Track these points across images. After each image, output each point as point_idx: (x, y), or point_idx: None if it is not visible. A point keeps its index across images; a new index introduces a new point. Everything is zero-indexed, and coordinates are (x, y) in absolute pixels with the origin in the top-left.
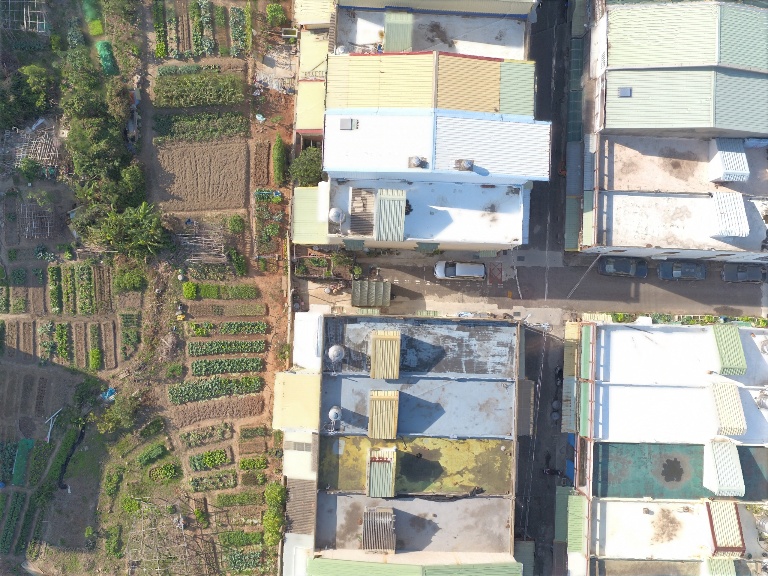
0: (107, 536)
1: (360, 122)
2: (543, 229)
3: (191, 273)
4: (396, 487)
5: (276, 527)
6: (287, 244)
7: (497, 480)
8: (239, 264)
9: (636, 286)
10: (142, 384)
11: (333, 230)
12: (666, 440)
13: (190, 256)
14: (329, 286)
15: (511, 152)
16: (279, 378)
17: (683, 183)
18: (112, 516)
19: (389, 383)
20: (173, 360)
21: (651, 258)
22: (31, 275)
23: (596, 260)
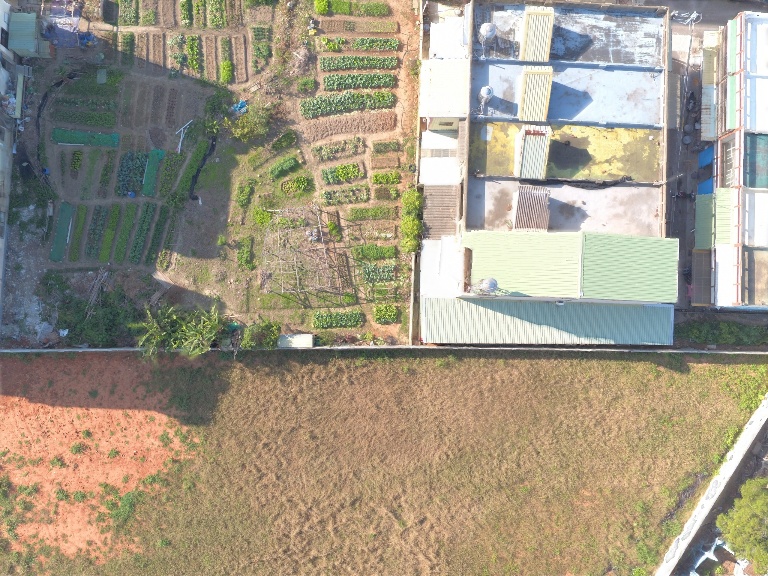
0: (239, 247)
1: None
2: None
3: None
4: None
5: (415, 230)
6: None
7: (645, 169)
8: None
9: None
10: (274, 97)
11: None
12: None
13: None
14: (459, 8)
15: None
16: (425, 66)
17: None
18: (244, 228)
19: None
20: (305, 74)
21: None
22: None
23: None
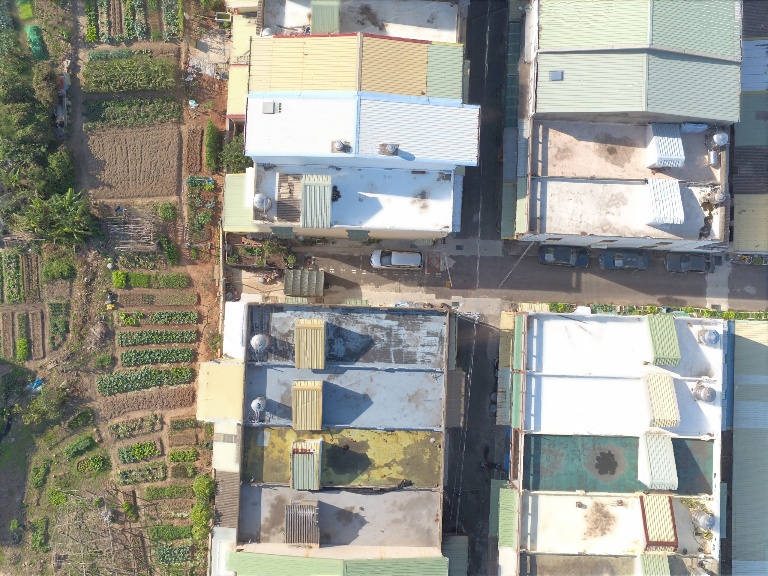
0: (33, 529)
1: (283, 105)
2: (483, 217)
3: (121, 261)
4: (322, 480)
5: (203, 520)
6: (219, 232)
7: (426, 473)
8: (170, 252)
9: (577, 276)
10: (70, 375)
11: (259, 217)
12: (600, 432)
13: (119, 244)
14: (263, 275)
15: (438, 136)
16: (203, 368)
17: (619, 169)
18: (39, 509)
19: (316, 373)
20: (102, 350)
21: (591, 247)
22: None
23: (528, 248)
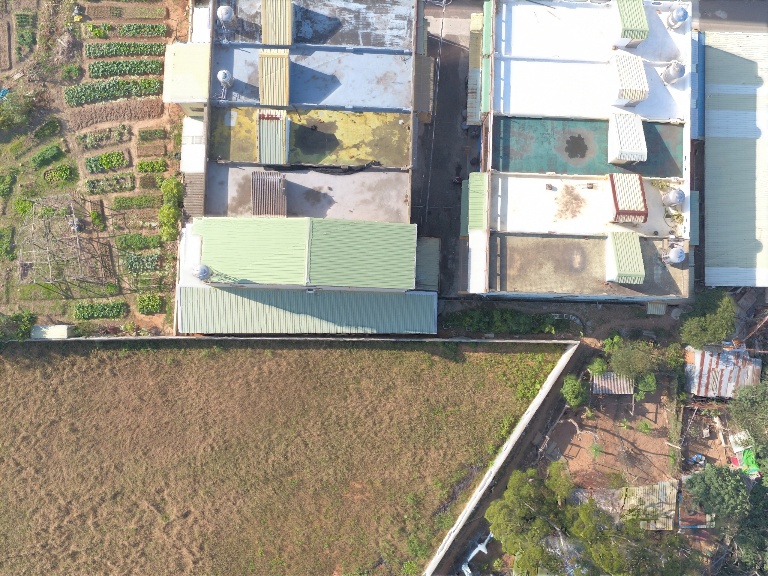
0: None
1: None
2: None
3: None
4: (290, 160)
5: (171, 218)
6: None
7: (395, 154)
8: None
9: None
10: (37, 85)
11: None
12: (569, 115)
13: None
14: None
15: None
16: (170, 50)
17: None
18: (5, 218)
19: None
20: (69, 61)
21: None
22: None
23: None
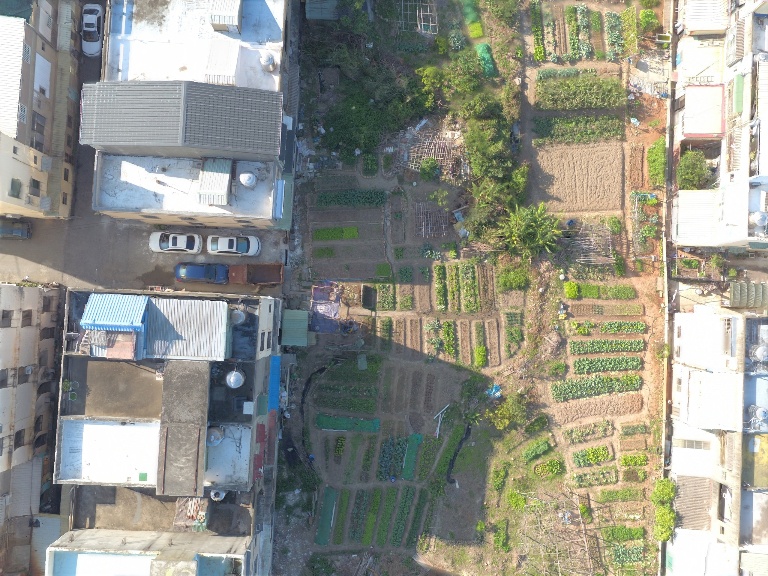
0: (495, 530)
1: None
2: None
3: (572, 273)
4: None
5: (671, 523)
6: (663, 246)
7: None
8: (619, 265)
9: None
10: (526, 381)
11: None
12: None
13: None
14: (699, 287)
15: None
16: (694, 377)
17: None
18: (499, 510)
19: None
20: (556, 358)
21: None
22: (417, 273)
23: None
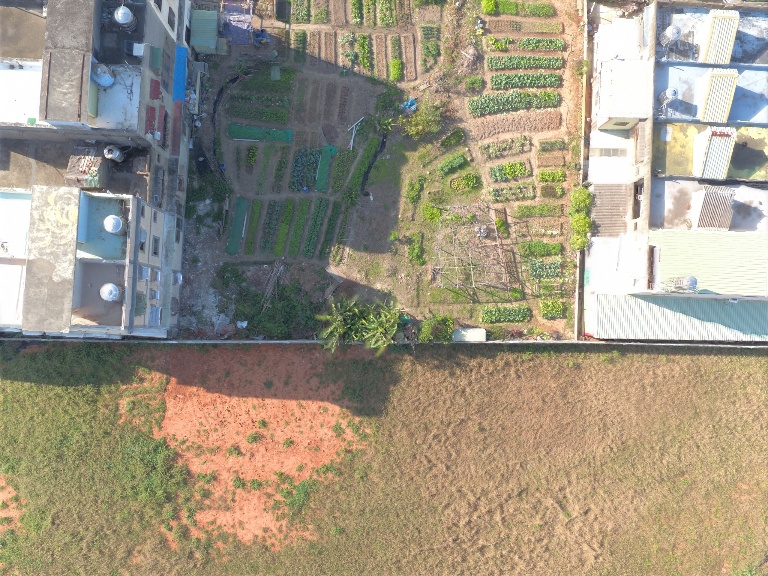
0: (410, 243)
1: None
2: None
3: None
4: None
5: (587, 228)
6: None
7: None
8: None
9: None
10: (442, 96)
11: None
12: None
13: None
14: (620, 10)
15: None
16: (606, 67)
17: None
18: (414, 224)
19: None
20: (473, 73)
21: None
22: None
23: None
